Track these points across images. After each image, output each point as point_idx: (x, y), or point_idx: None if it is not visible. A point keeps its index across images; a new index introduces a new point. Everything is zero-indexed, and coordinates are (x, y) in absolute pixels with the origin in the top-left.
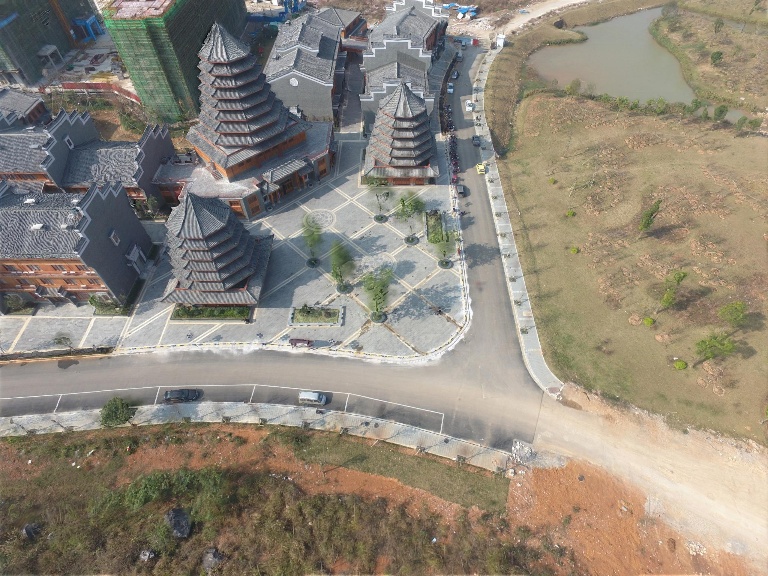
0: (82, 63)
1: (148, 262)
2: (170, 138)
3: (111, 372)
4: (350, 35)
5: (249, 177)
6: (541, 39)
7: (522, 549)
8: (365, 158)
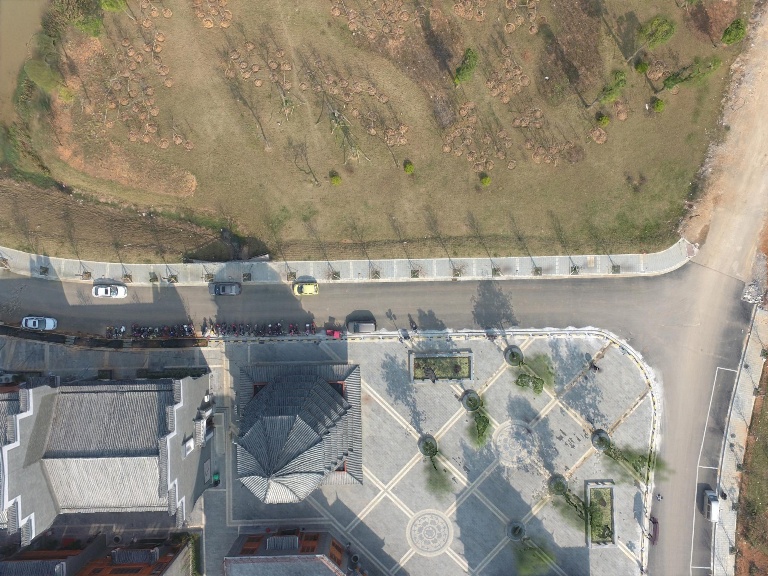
0: None
1: None
2: None
3: None
4: None
5: None
6: None
7: None
8: None
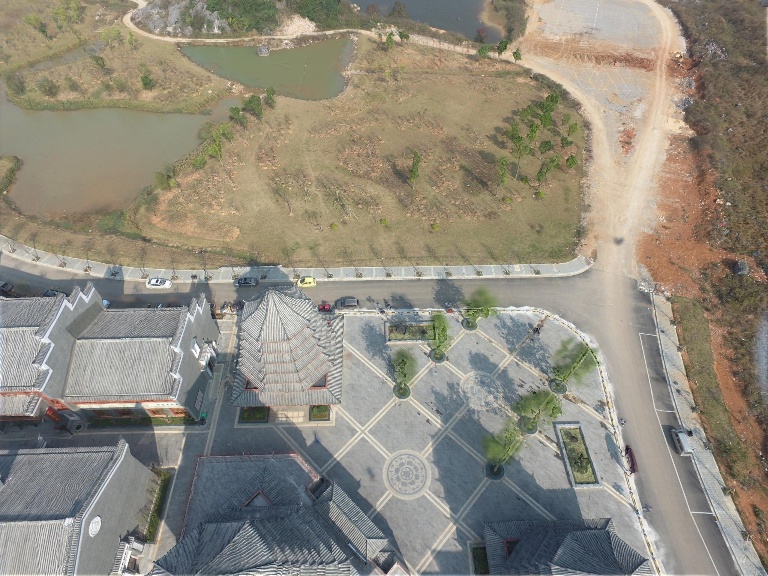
0: None
1: None
2: None
3: None
4: None
5: None
6: None
7: None
8: (295, 405)
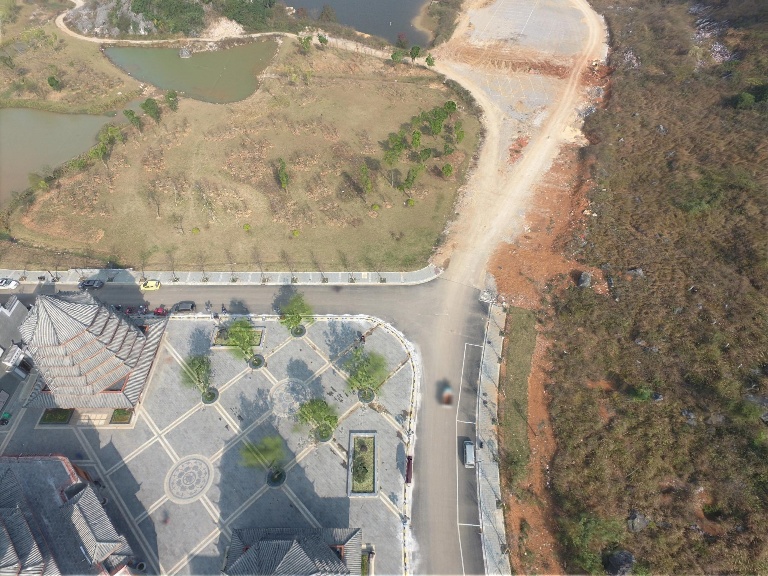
0: None
1: None
2: None
3: None
4: None
5: None
6: None
7: None
8: None
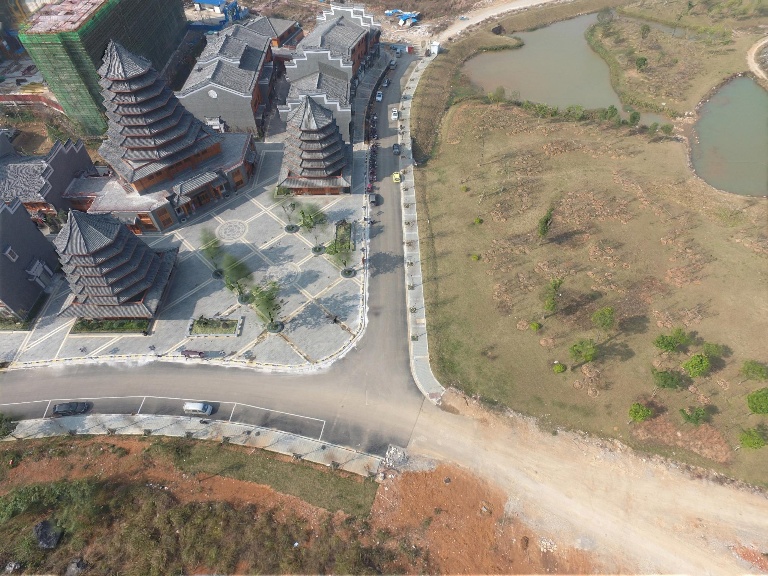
0: (14, 74)
1: (55, 276)
2: (86, 151)
3: (4, 387)
4: (283, 44)
5: (160, 190)
6: (478, 45)
7: (379, 551)
8: (281, 169)
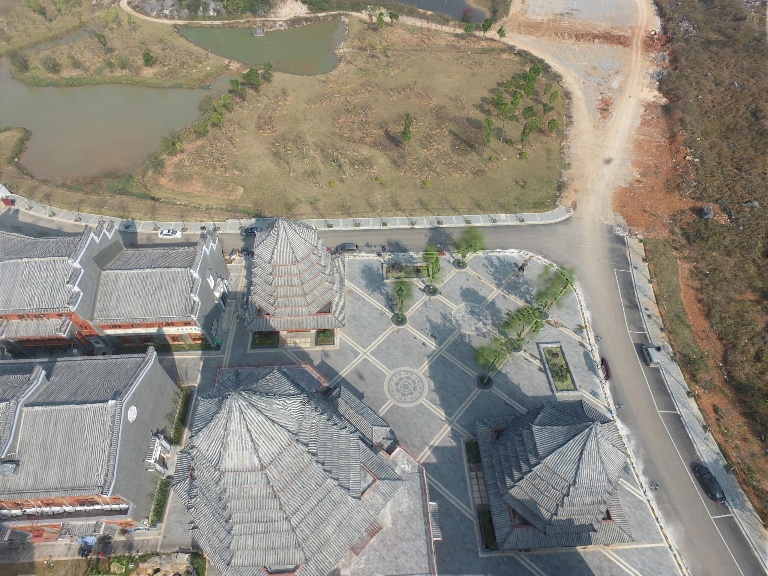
0: None
1: None
2: None
3: None
4: None
5: None
6: None
7: None
8: (303, 329)
